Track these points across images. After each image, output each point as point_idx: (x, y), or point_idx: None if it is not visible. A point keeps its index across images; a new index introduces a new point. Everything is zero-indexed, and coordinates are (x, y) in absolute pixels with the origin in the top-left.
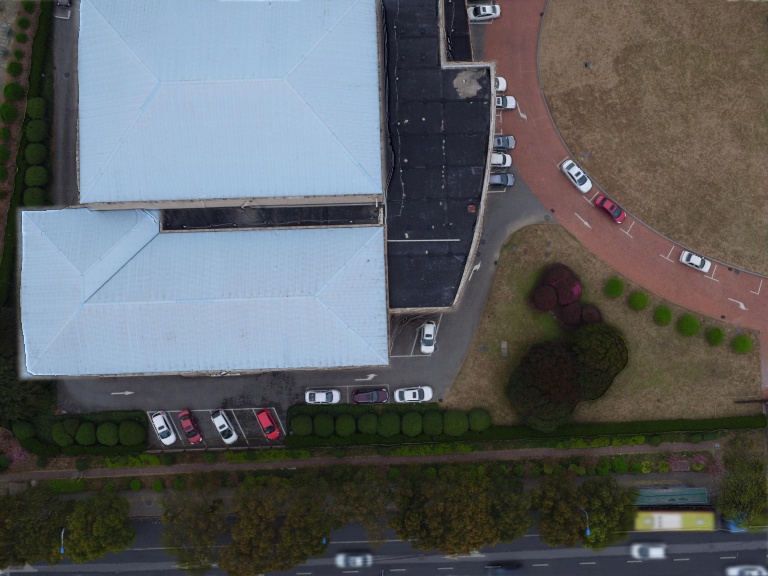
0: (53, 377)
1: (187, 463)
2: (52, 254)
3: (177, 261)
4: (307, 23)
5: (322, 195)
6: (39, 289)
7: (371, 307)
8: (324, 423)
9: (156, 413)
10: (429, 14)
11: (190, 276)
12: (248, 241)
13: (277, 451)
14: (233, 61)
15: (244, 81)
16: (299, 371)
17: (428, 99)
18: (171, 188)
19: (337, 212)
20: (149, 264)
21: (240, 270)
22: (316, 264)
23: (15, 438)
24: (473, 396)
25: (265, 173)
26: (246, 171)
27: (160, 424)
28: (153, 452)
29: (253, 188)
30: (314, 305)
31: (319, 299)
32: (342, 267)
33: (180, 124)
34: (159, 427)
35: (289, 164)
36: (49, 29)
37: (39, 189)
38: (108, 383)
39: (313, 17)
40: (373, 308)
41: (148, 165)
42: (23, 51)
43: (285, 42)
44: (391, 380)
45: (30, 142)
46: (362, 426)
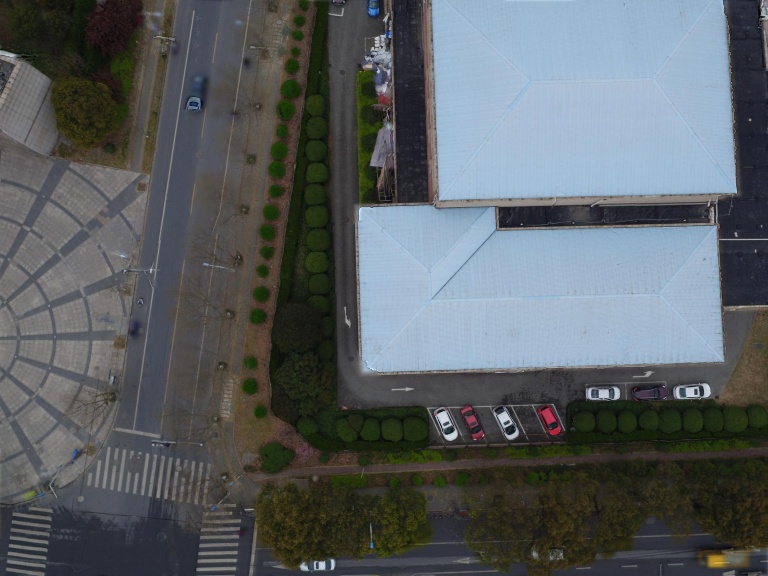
0: (335, 373)
1: (467, 459)
2: (395, 251)
3: (518, 258)
4: (665, 24)
5: (678, 194)
6: (380, 285)
7: (708, 305)
8: (609, 419)
9: (439, 409)
10: (753, 16)
11: (533, 273)
12: (589, 239)
13: (559, 447)
14: (599, 61)
15: (614, 81)
16: (578, 368)
17: (754, 100)
18: (525, 186)
19: (680, 211)
20: (491, 261)
21: (582, 268)
22: (657, 262)
23: (298, 434)
24: (749, 393)
25: (624, 172)
26: (606, 170)
27: (445, 420)
28: (435, 448)
29: (611, 187)
30: (658, 303)
31: (663, 297)
32: (682, 265)
33: (546, 123)
34: (444, 423)
35: (649, 163)
36: (326, 26)
37: (320, 186)
38: (388, 379)
39: (670, 18)
40: (710, 306)
41: (510, 163)
42: (299, 48)
43: (647, 43)
44: (668, 377)
45: (310, 139)
46: (645, 422)
